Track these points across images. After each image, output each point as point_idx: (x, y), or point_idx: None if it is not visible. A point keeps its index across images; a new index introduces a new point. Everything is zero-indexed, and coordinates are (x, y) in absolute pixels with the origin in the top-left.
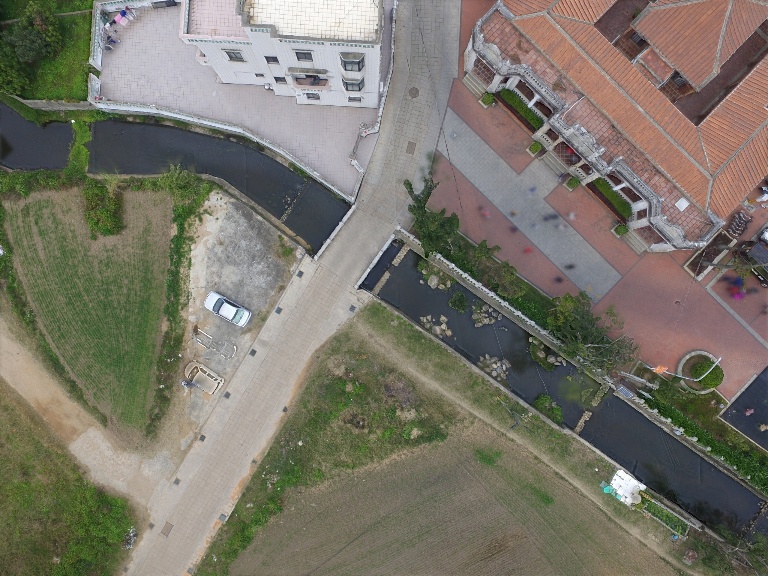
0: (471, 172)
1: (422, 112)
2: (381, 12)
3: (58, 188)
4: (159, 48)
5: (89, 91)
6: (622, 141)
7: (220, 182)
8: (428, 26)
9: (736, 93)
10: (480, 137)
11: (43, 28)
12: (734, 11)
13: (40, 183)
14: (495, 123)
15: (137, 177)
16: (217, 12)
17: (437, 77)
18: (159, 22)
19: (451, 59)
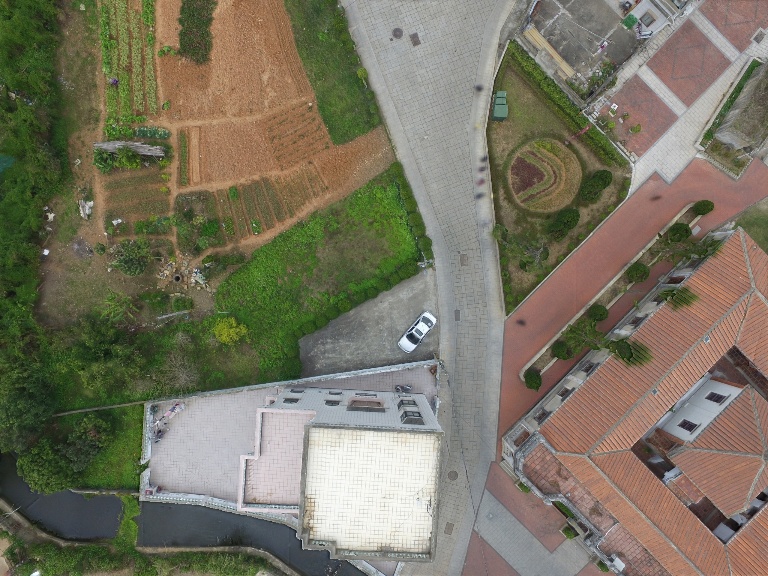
0: (506, 551)
1: (460, 494)
2: (436, 533)
3: (110, 571)
4: (207, 435)
5: (141, 491)
6: (654, 563)
7: (264, 555)
8: (468, 411)
9: (764, 514)
10: (515, 518)
11: (96, 438)
12: (767, 465)
13: (92, 566)
14: (530, 504)
15: (184, 551)
16: (272, 476)
17: (475, 460)
18: (207, 410)
19: (489, 443)
